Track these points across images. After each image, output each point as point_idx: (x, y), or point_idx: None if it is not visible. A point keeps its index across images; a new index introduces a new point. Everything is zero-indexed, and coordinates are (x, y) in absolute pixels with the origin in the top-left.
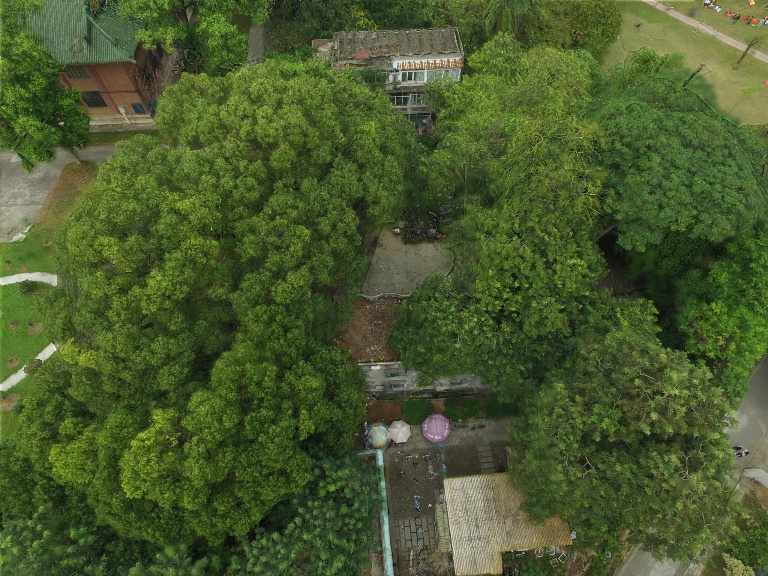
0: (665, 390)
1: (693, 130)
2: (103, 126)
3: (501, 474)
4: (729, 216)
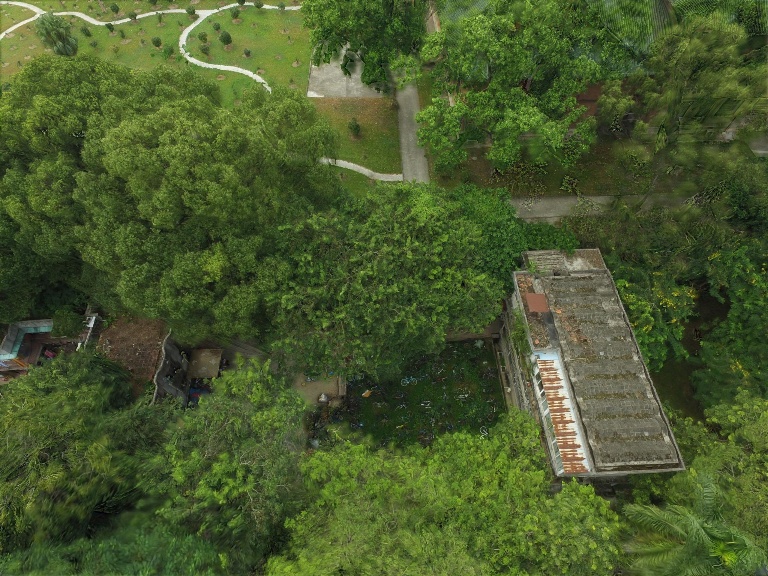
0: None
1: None
2: None
3: None
4: None
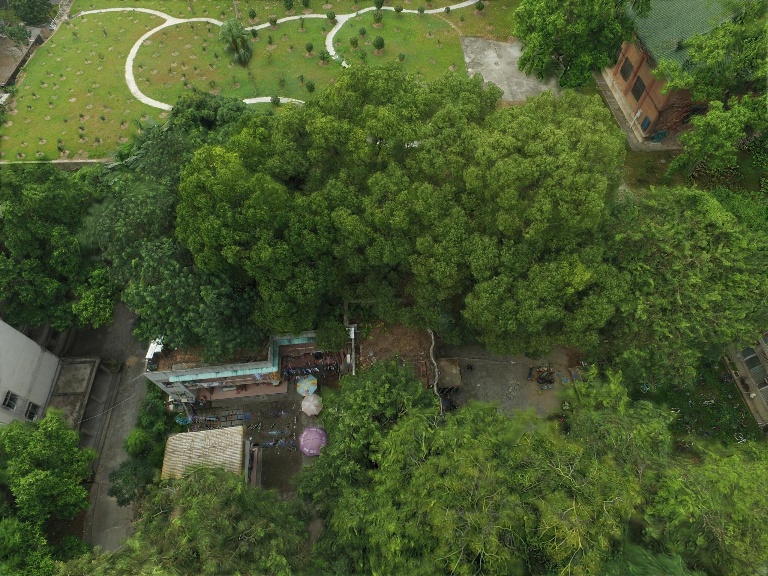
0: (158, 571)
1: None
2: (620, 111)
3: None
4: None
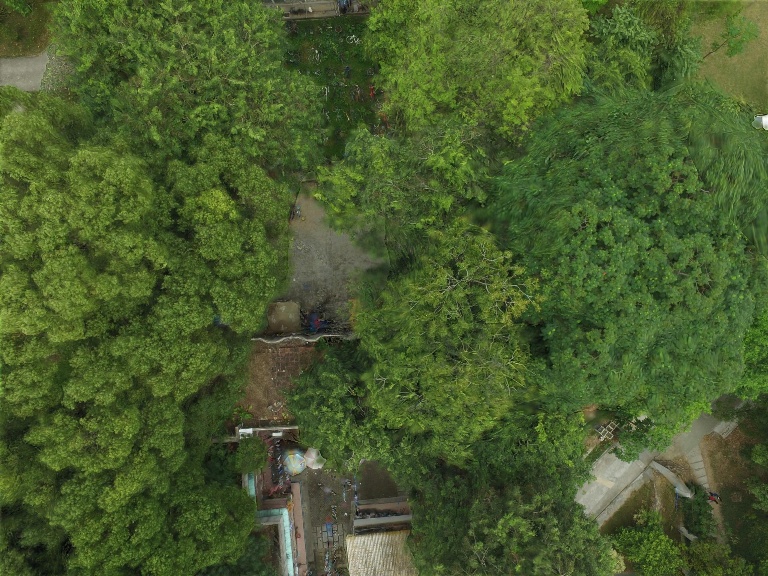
0: None
1: (681, 292)
2: None
3: (401, 533)
4: (687, 406)
